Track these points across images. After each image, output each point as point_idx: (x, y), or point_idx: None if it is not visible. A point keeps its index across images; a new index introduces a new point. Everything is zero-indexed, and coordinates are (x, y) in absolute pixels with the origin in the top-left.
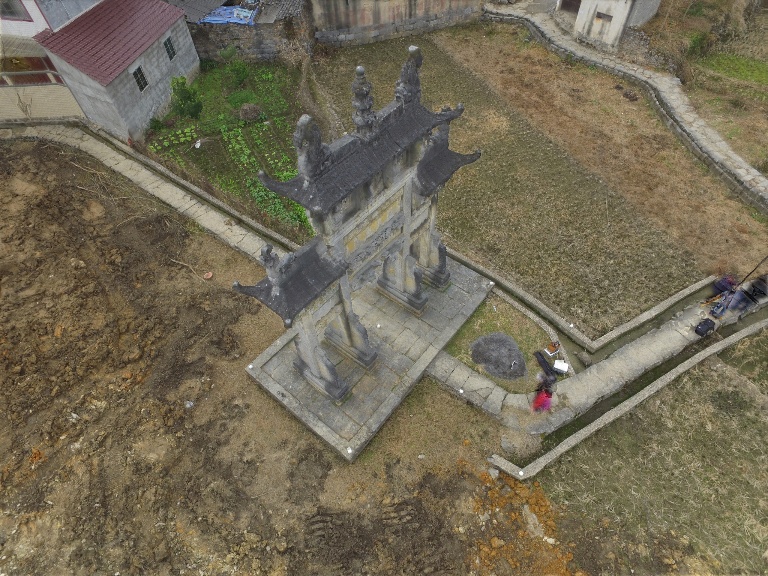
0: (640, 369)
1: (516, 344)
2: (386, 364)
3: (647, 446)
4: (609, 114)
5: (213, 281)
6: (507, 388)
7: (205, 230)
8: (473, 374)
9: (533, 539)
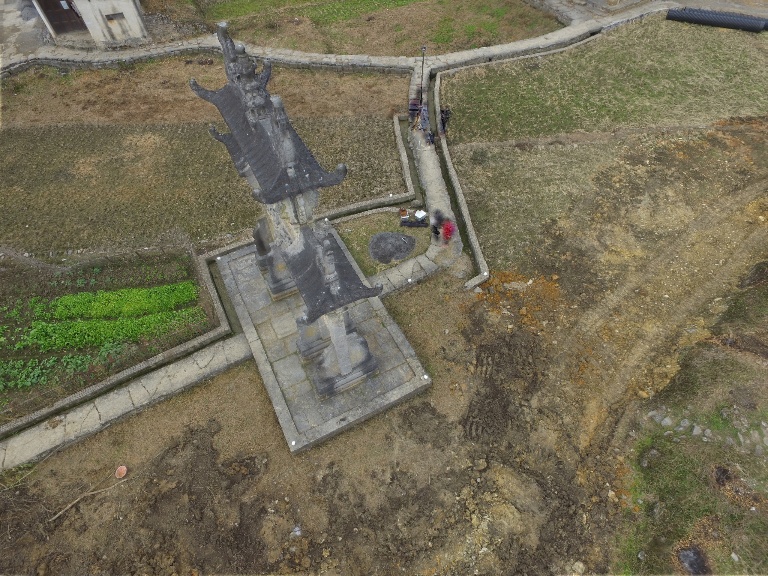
0: (442, 180)
1: (387, 232)
2: (357, 322)
3: (490, 207)
4: (212, 81)
5: (134, 468)
6: (420, 253)
7: (35, 461)
8: (399, 267)
9: (527, 290)
